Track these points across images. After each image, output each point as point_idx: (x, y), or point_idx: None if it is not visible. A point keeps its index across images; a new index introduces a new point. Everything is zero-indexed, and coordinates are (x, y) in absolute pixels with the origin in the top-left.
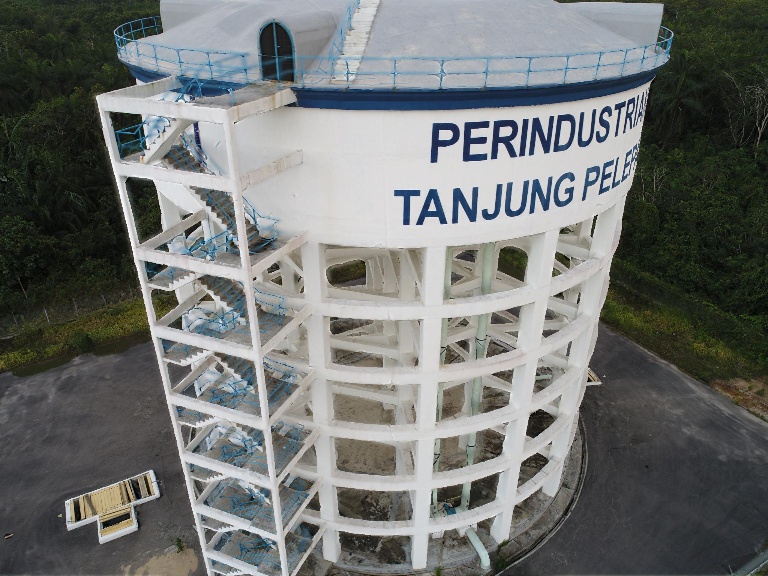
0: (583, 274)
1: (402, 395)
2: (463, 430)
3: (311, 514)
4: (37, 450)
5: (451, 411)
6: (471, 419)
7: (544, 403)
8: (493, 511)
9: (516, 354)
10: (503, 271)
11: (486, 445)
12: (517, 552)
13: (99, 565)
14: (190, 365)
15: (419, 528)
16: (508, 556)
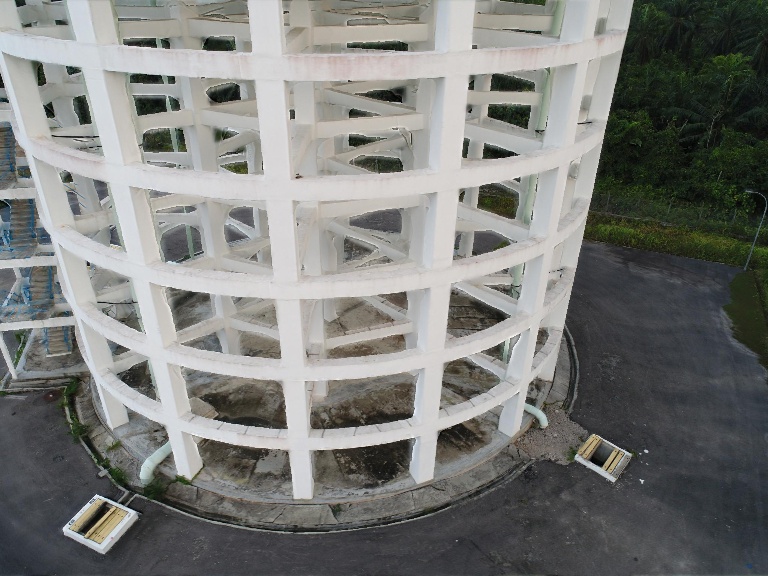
0: (174, 59)
1: (208, 248)
2: (73, 247)
3: None
4: None
5: None
6: (86, 240)
7: (173, 283)
8: (149, 411)
9: (96, 159)
10: (733, 304)
11: (338, 406)
12: (186, 501)
13: None
14: None
15: (92, 368)
16: (174, 495)
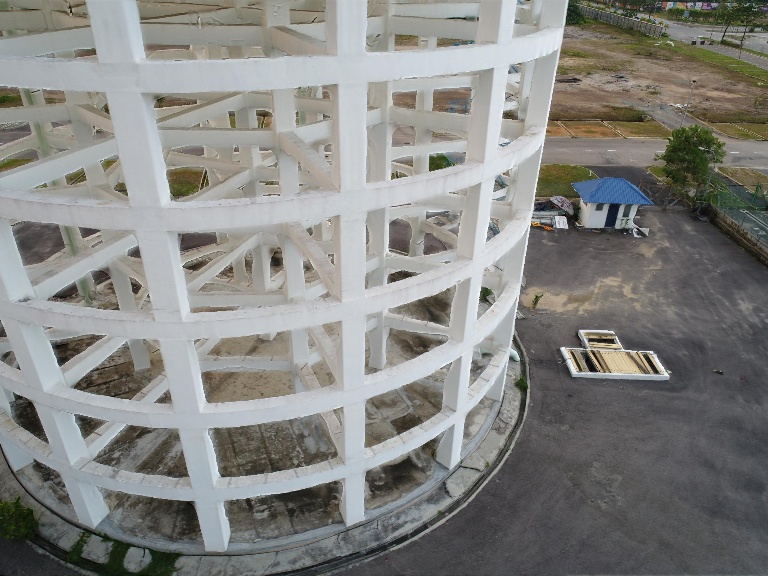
0: None
1: None
2: None
3: (431, 223)
4: (762, 472)
5: (212, 310)
6: None
7: None
8: None
9: None
10: None
11: None
12: None
13: (608, 322)
14: (527, 564)
15: None
16: None
